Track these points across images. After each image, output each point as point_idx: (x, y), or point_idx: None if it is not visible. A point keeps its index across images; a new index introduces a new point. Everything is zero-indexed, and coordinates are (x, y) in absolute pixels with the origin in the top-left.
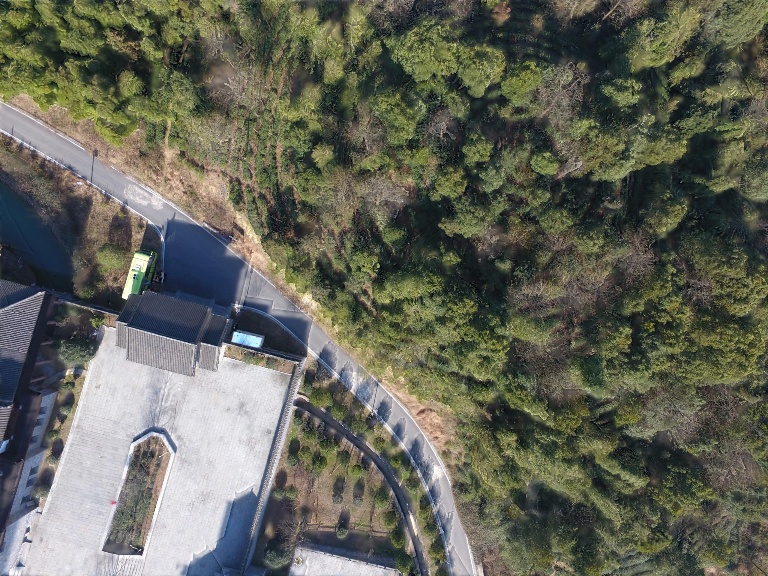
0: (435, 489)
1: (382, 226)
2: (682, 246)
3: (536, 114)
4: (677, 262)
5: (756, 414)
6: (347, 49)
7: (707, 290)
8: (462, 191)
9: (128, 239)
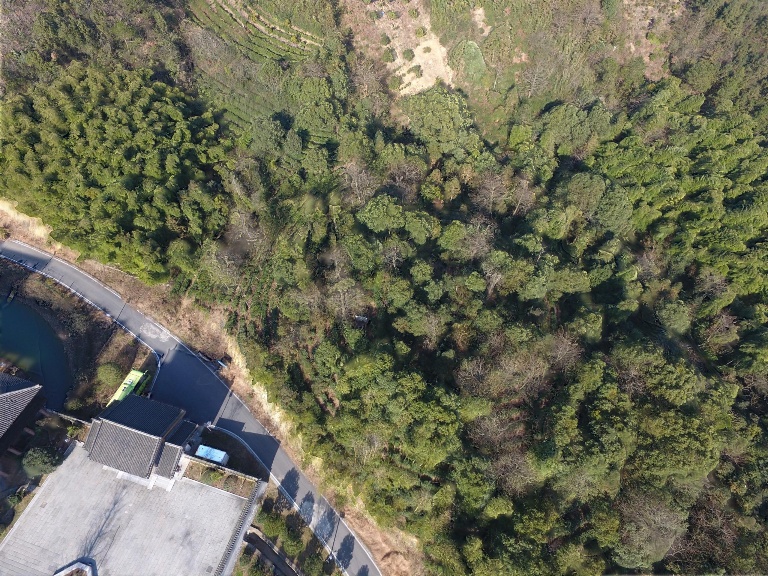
0: None
1: (347, 332)
2: (612, 355)
3: (467, 256)
4: (606, 359)
5: (765, 547)
6: (330, 220)
7: (640, 381)
8: (410, 297)
9: (130, 364)
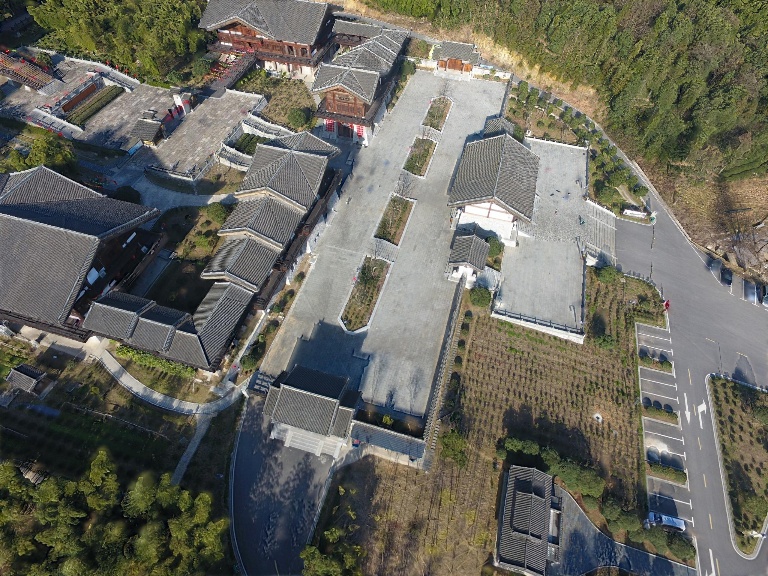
0: (594, 130)
1: None
2: None
3: None
4: None
5: None
6: None
7: None
8: None
9: None
